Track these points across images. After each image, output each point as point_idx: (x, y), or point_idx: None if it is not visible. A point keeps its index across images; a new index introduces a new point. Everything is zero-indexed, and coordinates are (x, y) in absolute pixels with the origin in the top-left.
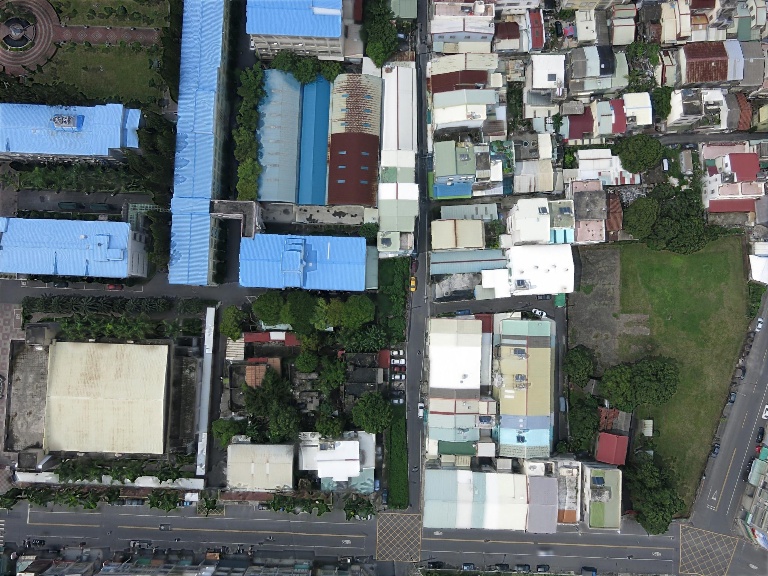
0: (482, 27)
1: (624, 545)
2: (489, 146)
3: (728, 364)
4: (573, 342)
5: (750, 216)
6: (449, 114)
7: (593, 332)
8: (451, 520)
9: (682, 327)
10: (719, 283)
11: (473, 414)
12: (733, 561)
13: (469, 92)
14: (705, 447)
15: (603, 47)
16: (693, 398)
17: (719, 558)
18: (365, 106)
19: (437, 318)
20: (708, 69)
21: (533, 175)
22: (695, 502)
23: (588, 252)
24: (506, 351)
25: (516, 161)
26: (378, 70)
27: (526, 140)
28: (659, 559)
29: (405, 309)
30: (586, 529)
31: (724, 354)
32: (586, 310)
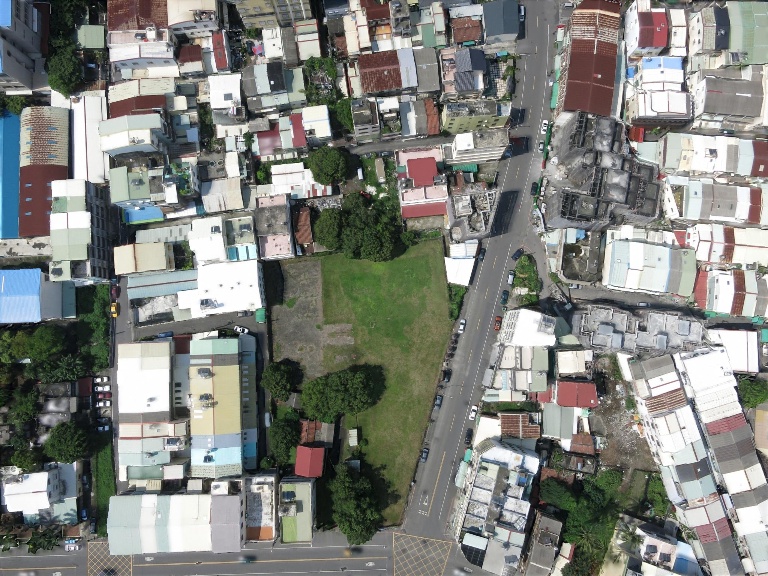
0: (160, 52)
1: (337, 557)
2: (167, 169)
3: (434, 368)
4: (278, 356)
5: (445, 219)
6: (113, 141)
7: (298, 345)
8: (136, 546)
9: (386, 334)
10: (421, 287)
11: (161, 437)
12: (447, 566)
13: (131, 118)
14: (415, 452)
15: (273, 64)
16: (400, 404)
17: (433, 564)
18: (49, 138)
19: (125, 343)
20: (382, 78)
21: (221, 194)
22: (407, 509)
23: (289, 266)
24: (193, 371)
25: (205, 181)
26: (67, 101)
27: (213, 160)
28: (373, 569)
29: (108, 335)
30: (298, 544)
31: (429, 358)
32: (290, 324)
